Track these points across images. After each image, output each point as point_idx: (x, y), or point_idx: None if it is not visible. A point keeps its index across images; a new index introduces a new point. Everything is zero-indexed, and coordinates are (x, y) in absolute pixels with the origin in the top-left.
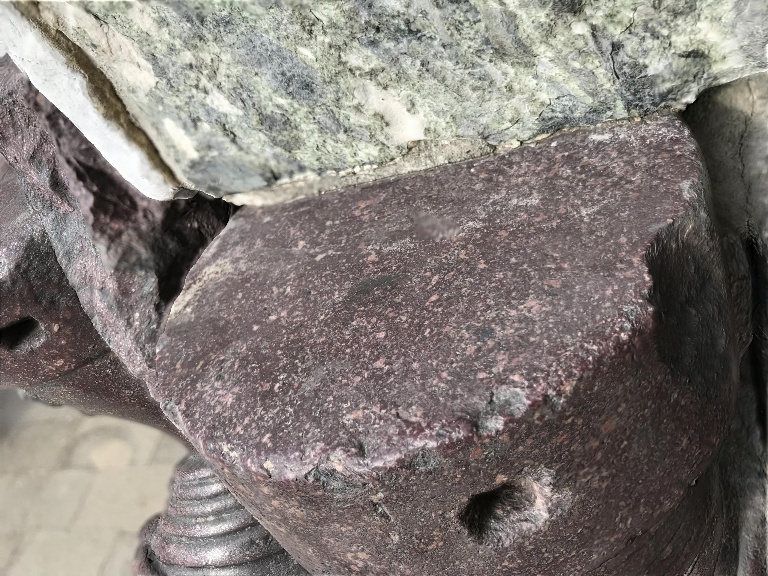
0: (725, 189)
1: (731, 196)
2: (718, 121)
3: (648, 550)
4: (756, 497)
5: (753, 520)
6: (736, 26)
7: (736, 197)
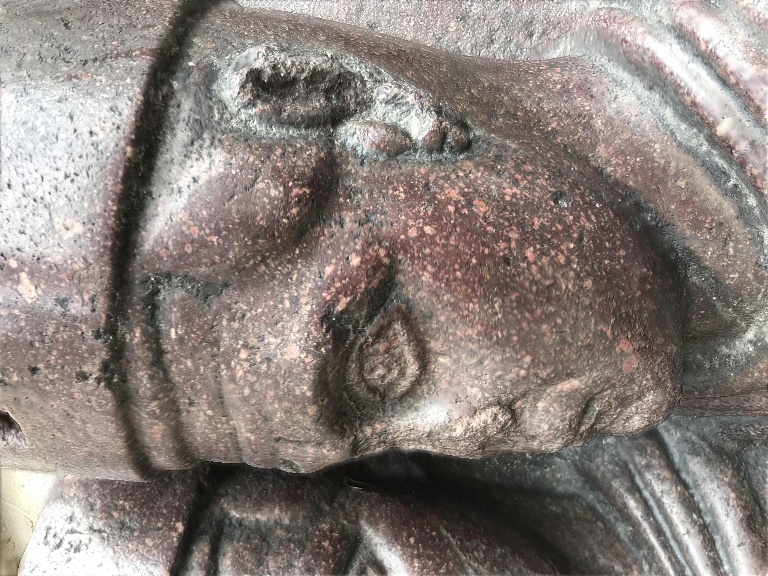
0: None
1: None
2: None
3: None
4: None
5: None
6: None
7: None
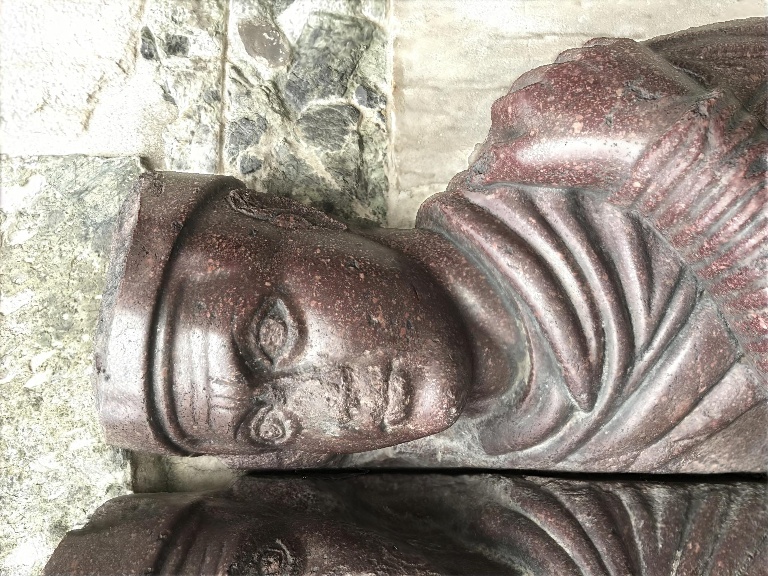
0: (216, 479)
1: (221, 477)
2: (186, 478)
3: (188, 569)
4: (494, 489)
5: (504, 495)
6: (102, 474)
7: (222, 475)
